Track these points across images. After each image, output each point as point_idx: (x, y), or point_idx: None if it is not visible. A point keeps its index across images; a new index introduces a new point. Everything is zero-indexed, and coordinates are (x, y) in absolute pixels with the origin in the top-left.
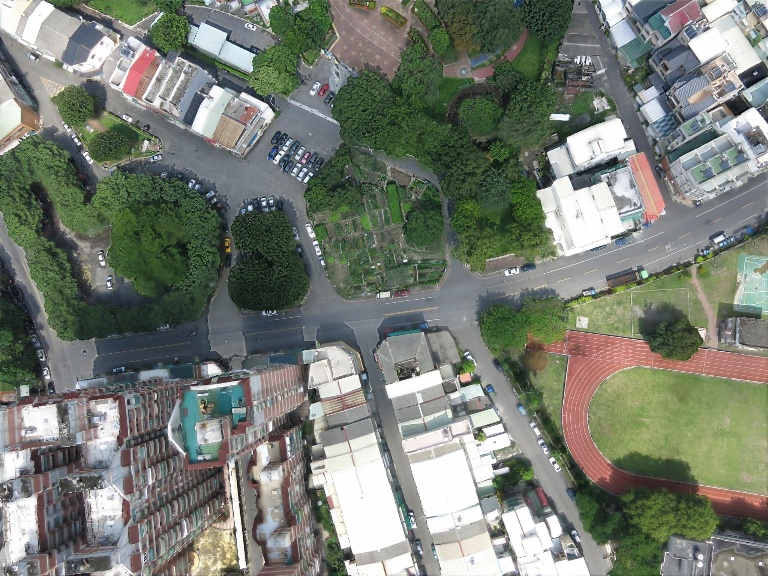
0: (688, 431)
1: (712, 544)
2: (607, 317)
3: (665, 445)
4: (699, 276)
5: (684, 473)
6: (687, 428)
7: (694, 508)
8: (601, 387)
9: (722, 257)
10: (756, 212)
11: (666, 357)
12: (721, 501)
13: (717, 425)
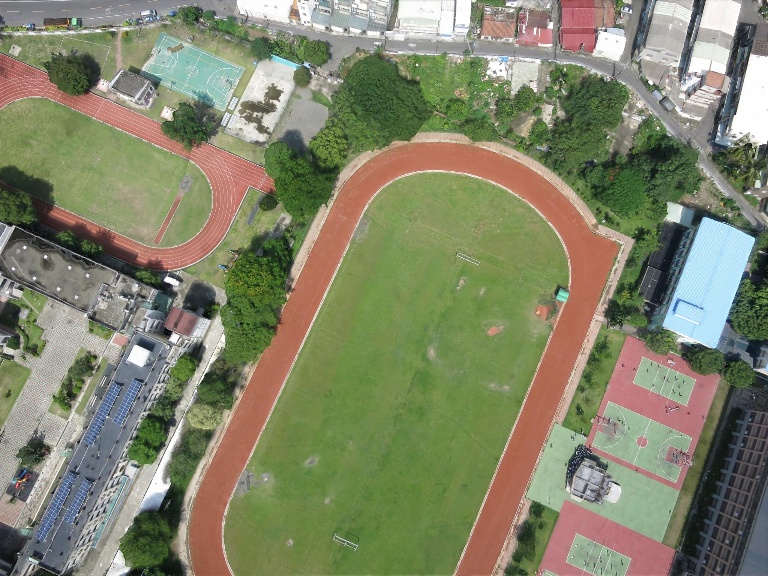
0: (63, 160)
1: (5, 226)
2: (37, 52)
3: (40, 166)
4: (123, 40)
5: (47, 193)
6: (64, 157)
7: (2, 193)
8: (8, 106)
9: (147, 31)
10: (187, 4)
11: (59, 88)
12: (66, 222)
13: (88, 161)
